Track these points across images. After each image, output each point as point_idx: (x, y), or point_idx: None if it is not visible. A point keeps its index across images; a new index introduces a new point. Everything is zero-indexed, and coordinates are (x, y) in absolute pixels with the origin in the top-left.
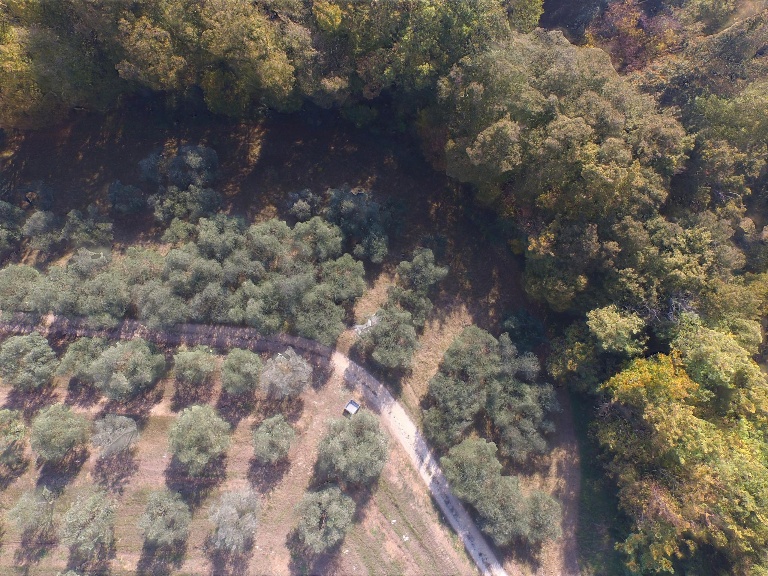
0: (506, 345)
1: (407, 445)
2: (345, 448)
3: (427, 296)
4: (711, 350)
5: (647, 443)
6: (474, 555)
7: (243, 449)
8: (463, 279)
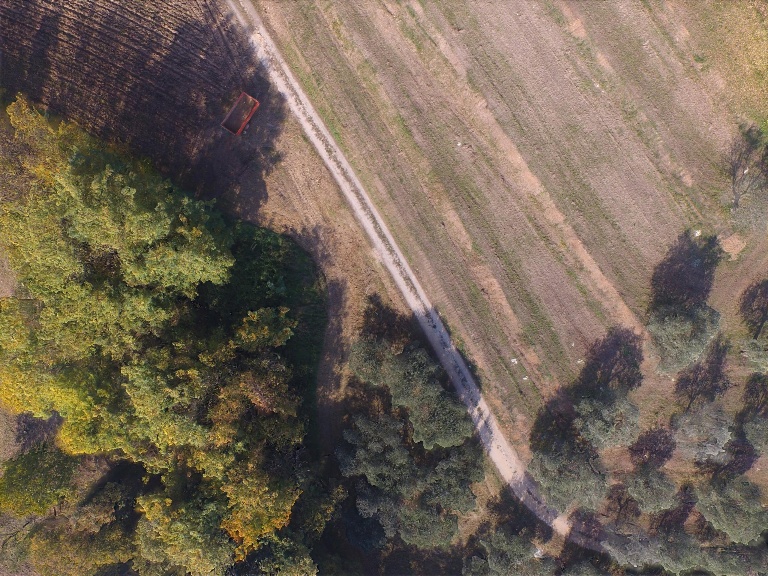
0: (391, 528)
1: (500, 439)
2: (586, 490)
3: (461, 568)
4: (208, 567)
5: (262, 435)
6: (441, 327)
7: (676, 468)
8: (417, 571)
